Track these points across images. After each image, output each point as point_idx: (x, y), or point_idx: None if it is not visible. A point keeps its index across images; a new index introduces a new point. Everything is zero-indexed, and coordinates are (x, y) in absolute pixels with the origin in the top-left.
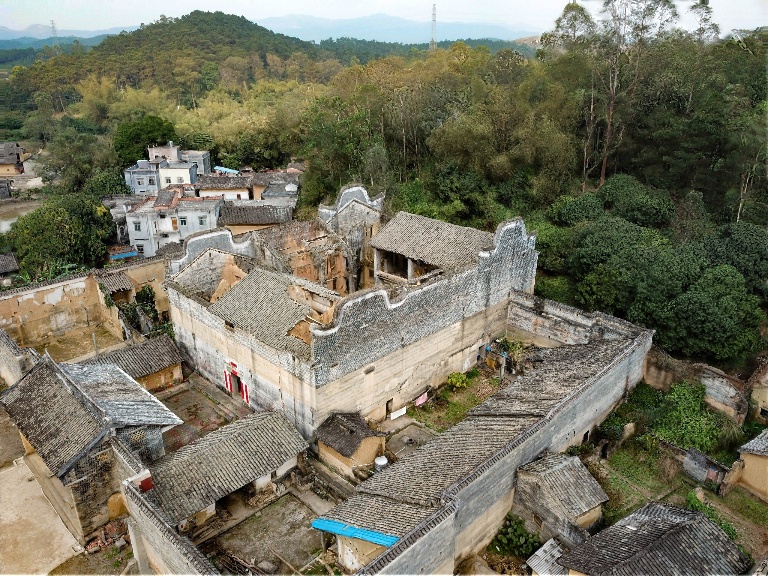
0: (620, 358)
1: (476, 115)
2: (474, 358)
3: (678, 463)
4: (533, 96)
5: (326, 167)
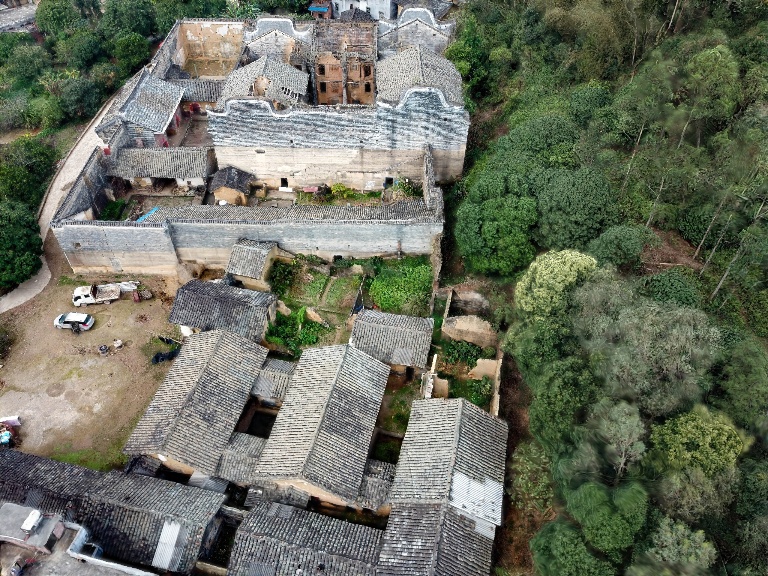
0: (379, 221)
1: None
2: (380, 183)
3: None
4: None
5: None
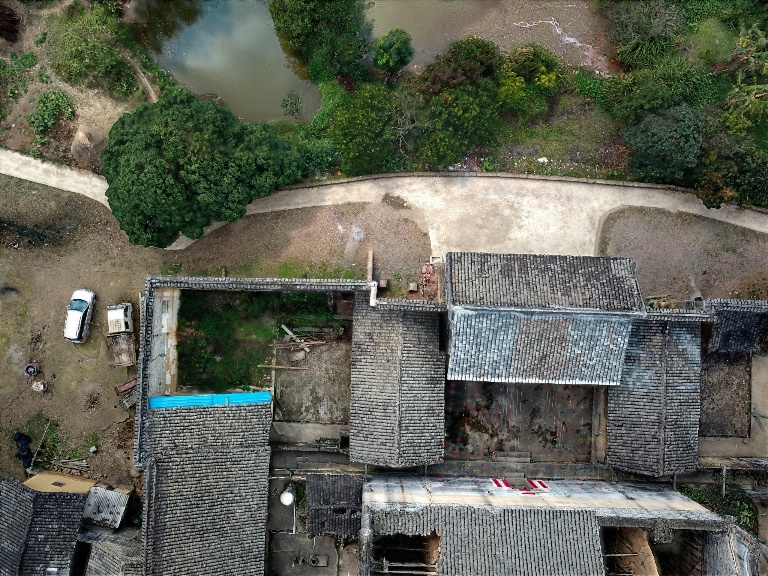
0: None
1: None
2: None
3: None
4: None
5: None
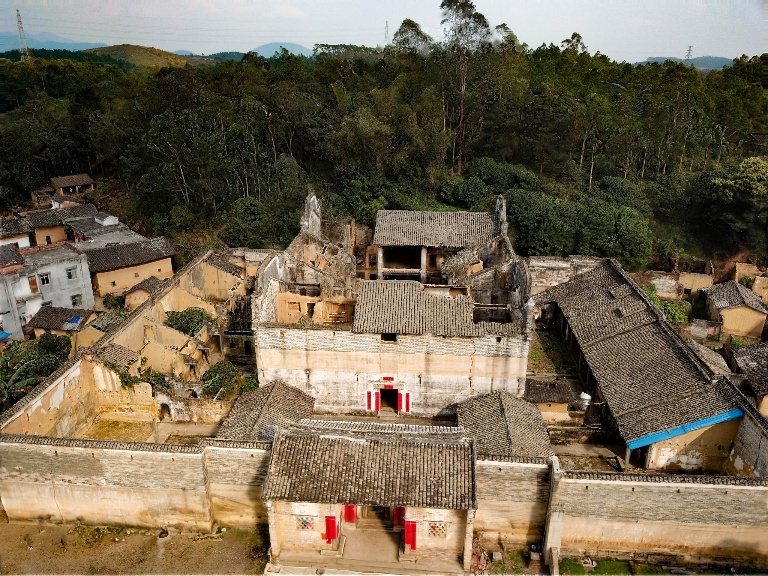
0: None
1: (370, 118)
2: None
3: (688, 332)
4: (403, 99)
5: (208, 186)
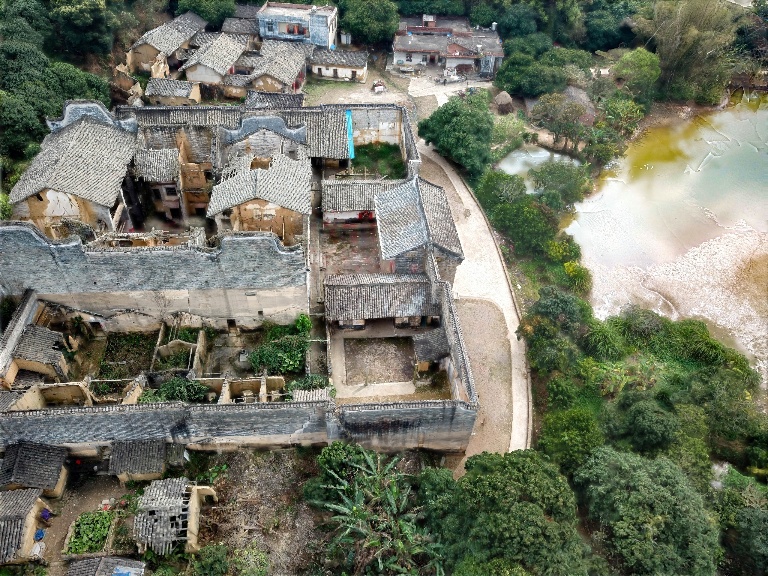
0: None
1: None
2: None
3: None
4: None
5: None
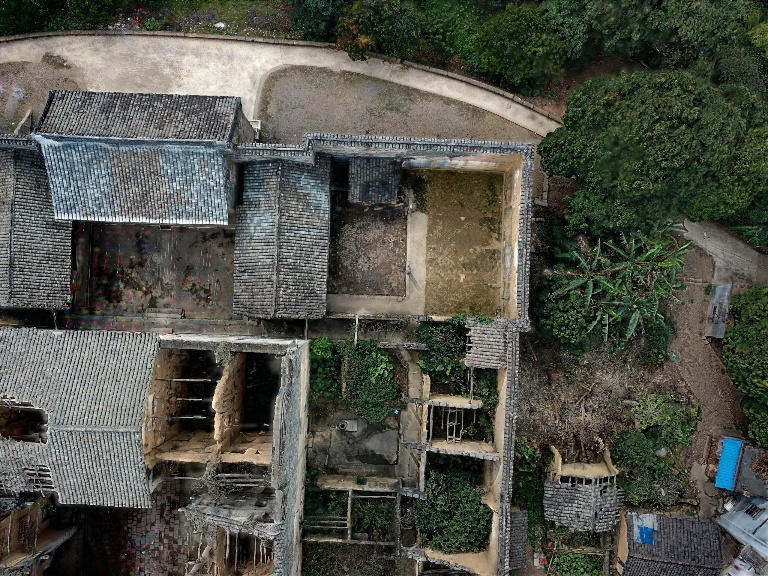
0: None
1: None
2: None
3: None
4: None
5: None
